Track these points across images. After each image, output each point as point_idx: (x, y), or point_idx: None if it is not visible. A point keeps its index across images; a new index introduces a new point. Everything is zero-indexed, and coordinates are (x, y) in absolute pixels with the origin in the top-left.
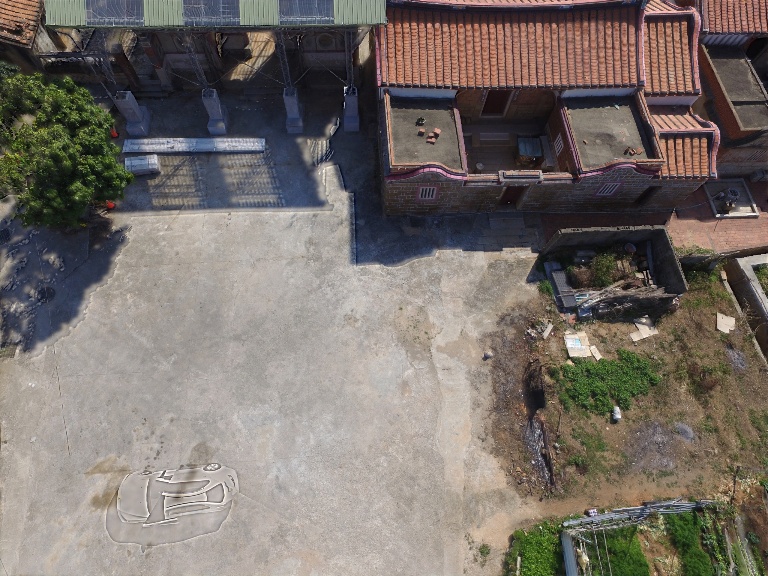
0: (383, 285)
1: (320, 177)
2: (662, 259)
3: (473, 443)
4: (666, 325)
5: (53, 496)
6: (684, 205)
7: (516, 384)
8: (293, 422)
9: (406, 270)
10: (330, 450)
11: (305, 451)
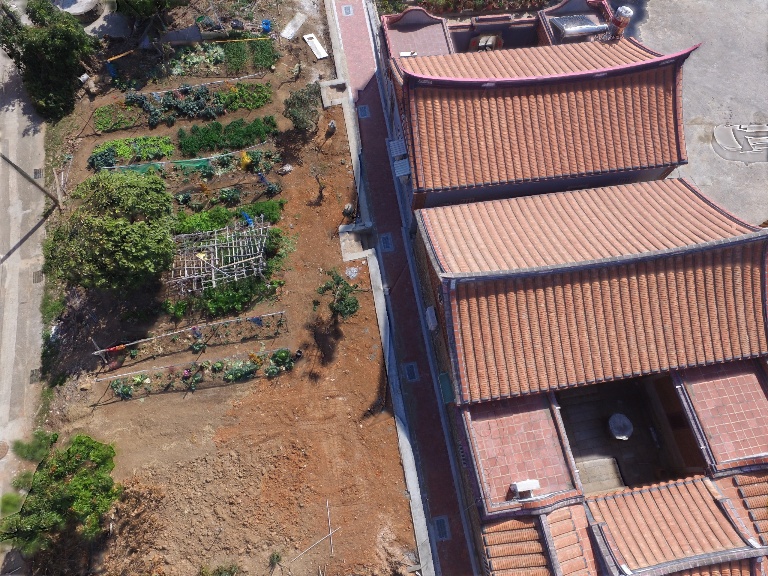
0: None
1: None
2: None
3: None
4: None
5: None
6: None
7: None
8: None
9: None
10: None
11: None
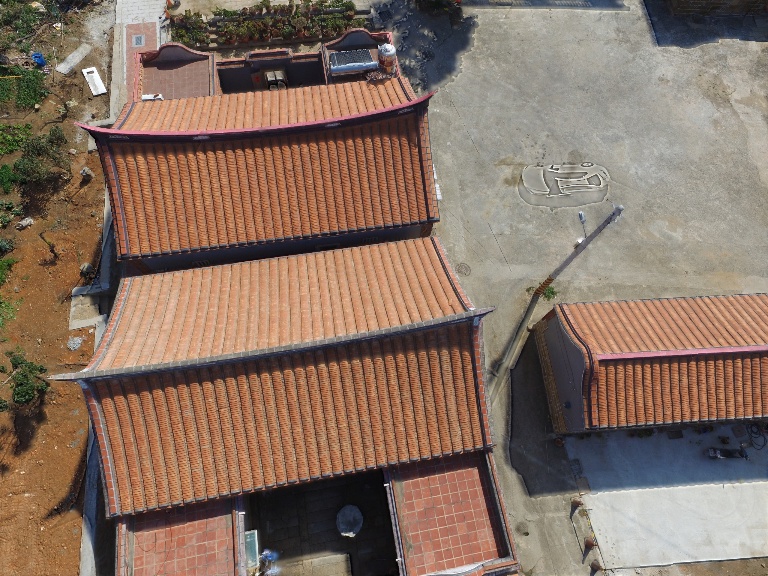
0: (683, 60)
1: None
2: None
3: None
4: None
5: (475, 177)
6: None
7: None
8: (639, 141)
9: (698, 51)
10: (671, 159)
11: (652, 158)
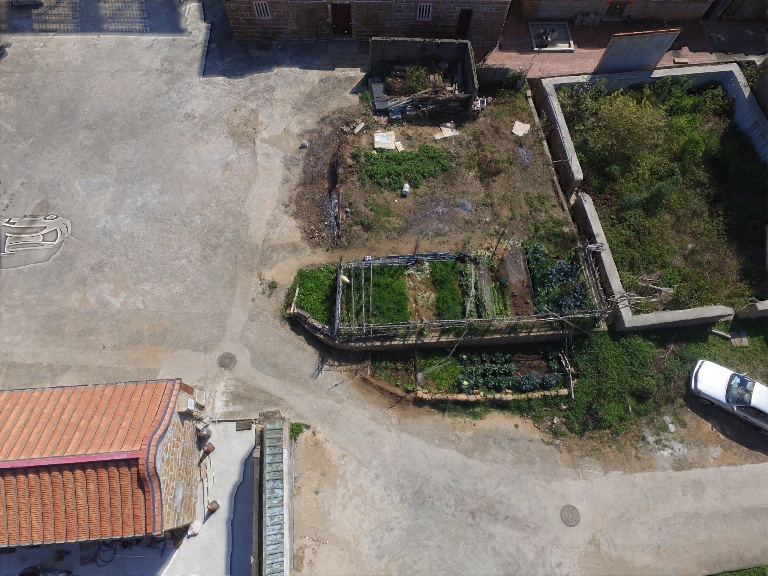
0: (223, 92)
1: (184, 11)
2: (467, 71)
3: (277, 208)
4: (468, 129)
5: None
6: (508, 41)
7: (323, 166)
8: (125, 188)
9: (246, 82)
10: (153, 209)
11: (132, 209)
